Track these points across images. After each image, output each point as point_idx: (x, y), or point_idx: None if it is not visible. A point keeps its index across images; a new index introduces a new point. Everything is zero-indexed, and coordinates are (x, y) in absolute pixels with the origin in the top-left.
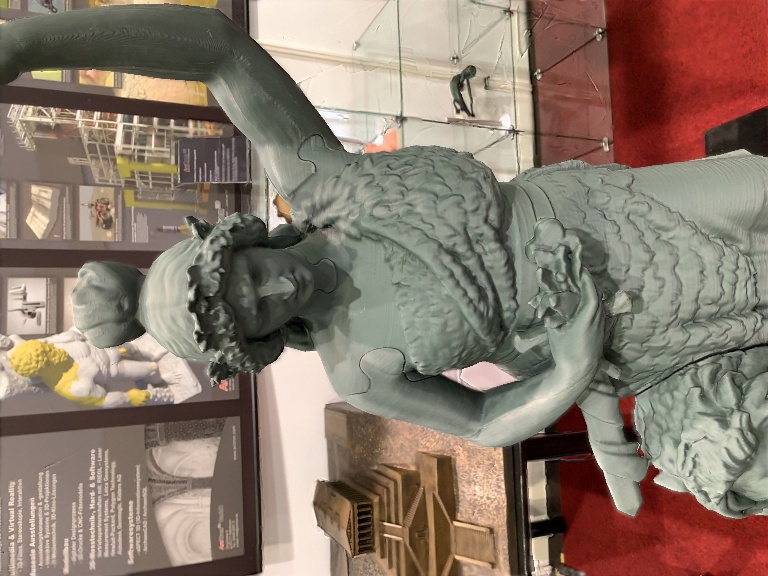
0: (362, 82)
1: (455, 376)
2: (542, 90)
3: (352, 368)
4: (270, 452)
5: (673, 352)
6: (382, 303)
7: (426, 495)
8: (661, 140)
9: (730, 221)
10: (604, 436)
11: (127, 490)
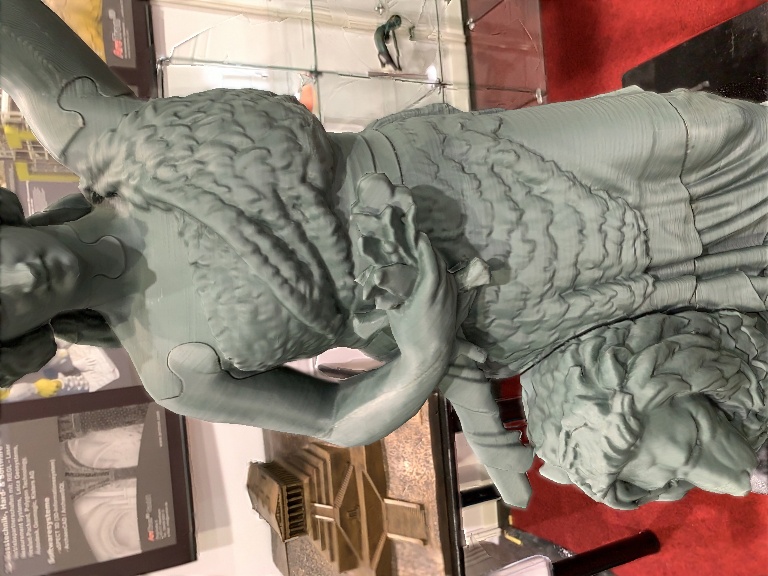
0: (270, 34)
1: (306, 366)
2: (476, 41)
3: (159, 368)
4: (201, 435)
5: (550, 326)
6: (180, 288)
7: (356, 473)
8: (593, 89)
9: (614, 169)
10: (477, 427)
11: (42, 487)
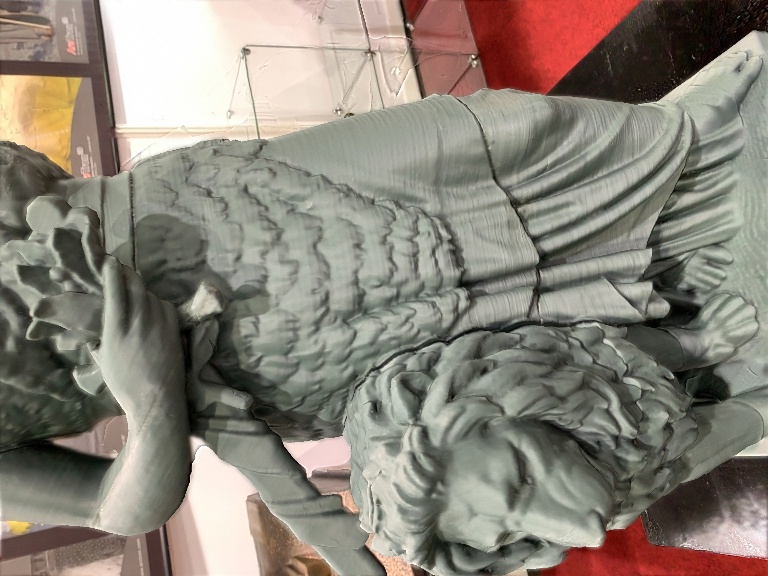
0: None
1: (85, 443)
2: None
3: None
4: (189, 562)
5: (337, 359)
6: None
7: None
8: None
9: (398, 176)
10: (275, 493)
11: None
